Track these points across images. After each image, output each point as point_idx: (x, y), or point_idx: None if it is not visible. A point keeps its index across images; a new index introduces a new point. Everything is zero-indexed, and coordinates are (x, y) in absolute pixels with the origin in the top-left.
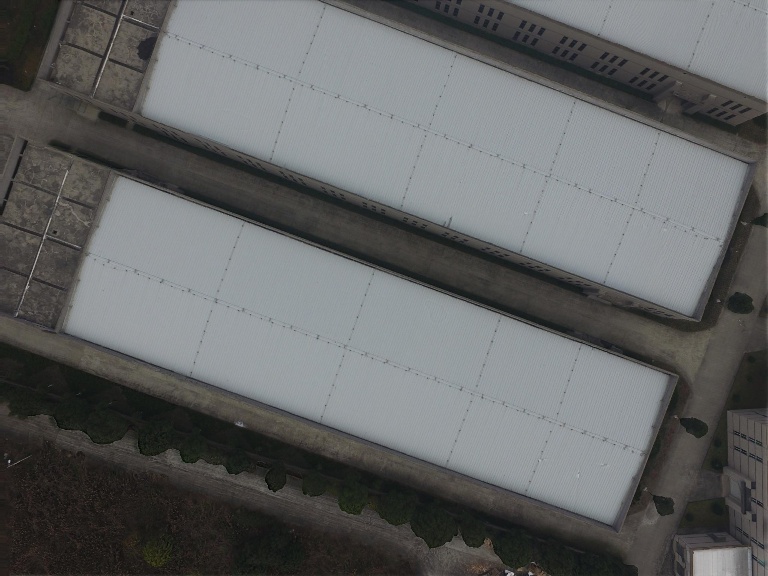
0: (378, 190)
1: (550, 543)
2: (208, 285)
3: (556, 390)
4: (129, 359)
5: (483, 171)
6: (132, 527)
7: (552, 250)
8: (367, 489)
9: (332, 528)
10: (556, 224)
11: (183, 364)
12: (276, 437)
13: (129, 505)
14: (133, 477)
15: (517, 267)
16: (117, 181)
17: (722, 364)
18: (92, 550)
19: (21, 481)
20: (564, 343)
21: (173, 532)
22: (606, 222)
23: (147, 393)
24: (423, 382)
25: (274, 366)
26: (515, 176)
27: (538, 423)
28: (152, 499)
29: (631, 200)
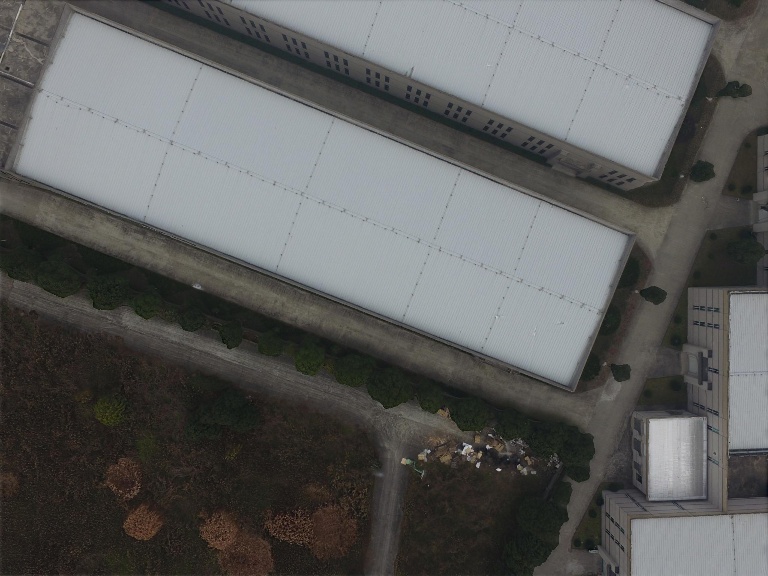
0: (339, 37)
1: (507, 410)
2: (164, 126)
3: (514, 246)
4: (81, 200)
5: (446, 20)
6: (85, 387)
7: (514, 104)
8: (324, 351)
9: (289, 395)
10: (518, 78)
11: (137, 208)
12: (234, 301)
13: (82, 366)
14: (87, 337)
15: (481, 134)
16: (73, 17)
17: (684, 241)
18: (43, 410)
19: None
20: (524, 199)
21: (126, 393)
22: (568, 77)
23: (103, 252)
24: (380, 233)
25: (230, 212)
26: (478, 26)
27: (495, 278)
28: (106, 360)
29: (594, 55)
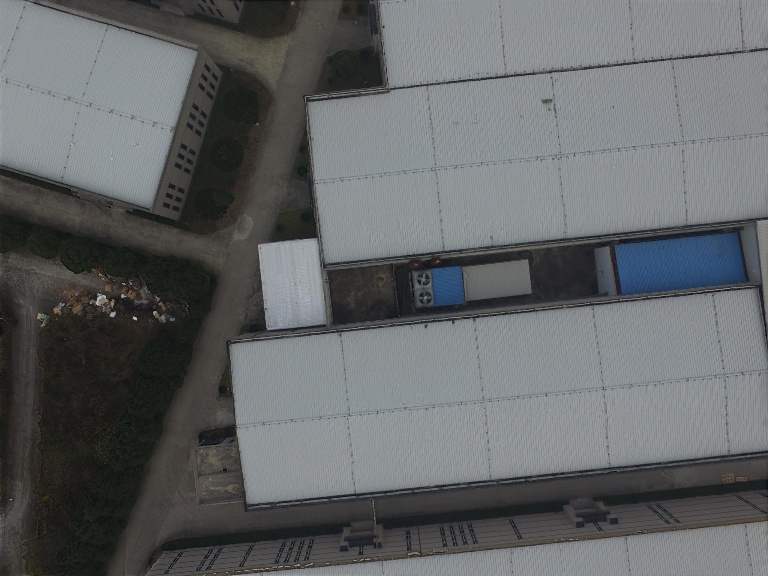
0: None
1: None
2: None
3: (82, 71)
4: None
5: None
6: None
7: None
8: None
9: None
10: None
11: None
12: None
13: None
14: None
15: None
16: None
17: (304, 69)
18: None
19: None
20: (91, 26)
21: None
22: None
23: None
24: None
25: None
26: None
27: (65, 105)
28: None
29: None
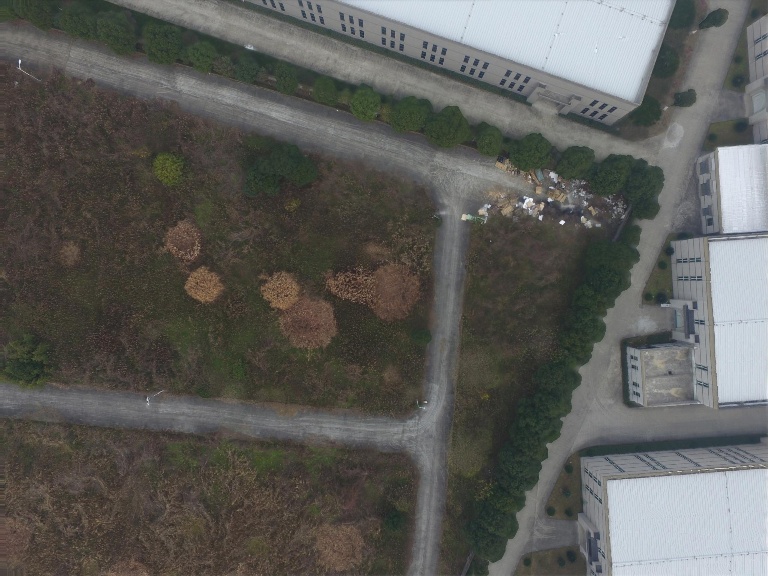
0: None
1: None
2: None
3: None
4: None
5: None
6: None
7: None
8: None
9: (345, 154)
10: None
11: None
12: (286, 60)
13: (139, 131)
14: (143, 101)
15: None
16: None
17: None
18: (102, 173)
19: (31, 98)
20: None
21: (184, 153)
22: None
23: (156, 17)
24: None
25: None
26: None
27: None
28: (162, 124)
29: None
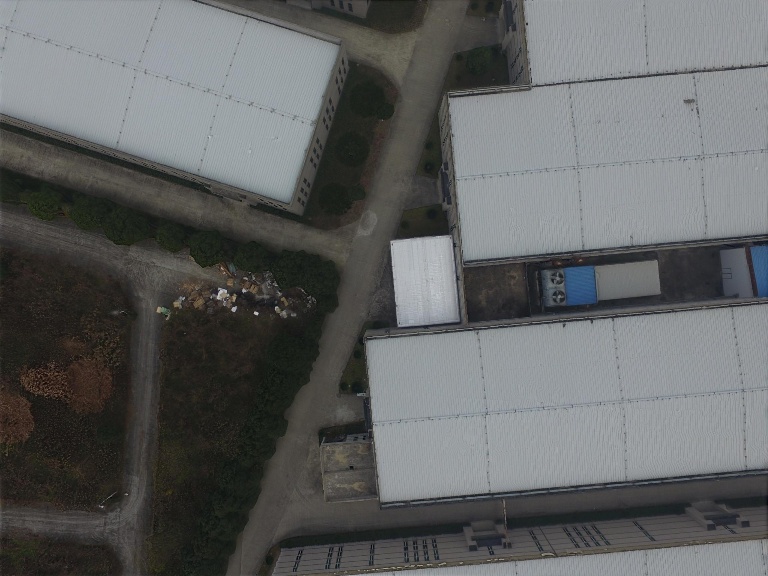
0: None
1: (247, 243)
2: None
3: (221, 63)
4: None
5: None
6: None
7: None
8: (61, 196)
9: (41, 249)
10: None
11: None
12: None
13: None
14: None
15: None
16: None
17: (430, 65)
18: None
19: None
20: (230, 18)
21: None
22: None
23: None
24: (86, 60)
25: None
26: None
27: (204, 97)
28: None
29: None
